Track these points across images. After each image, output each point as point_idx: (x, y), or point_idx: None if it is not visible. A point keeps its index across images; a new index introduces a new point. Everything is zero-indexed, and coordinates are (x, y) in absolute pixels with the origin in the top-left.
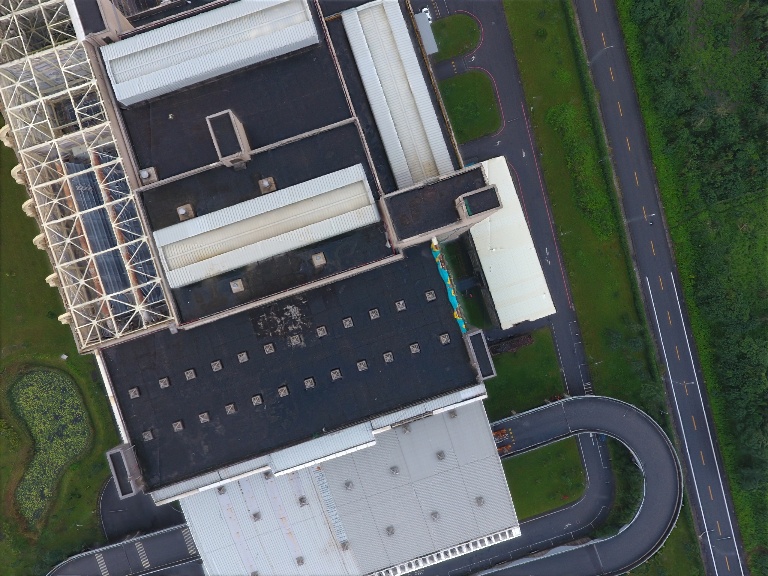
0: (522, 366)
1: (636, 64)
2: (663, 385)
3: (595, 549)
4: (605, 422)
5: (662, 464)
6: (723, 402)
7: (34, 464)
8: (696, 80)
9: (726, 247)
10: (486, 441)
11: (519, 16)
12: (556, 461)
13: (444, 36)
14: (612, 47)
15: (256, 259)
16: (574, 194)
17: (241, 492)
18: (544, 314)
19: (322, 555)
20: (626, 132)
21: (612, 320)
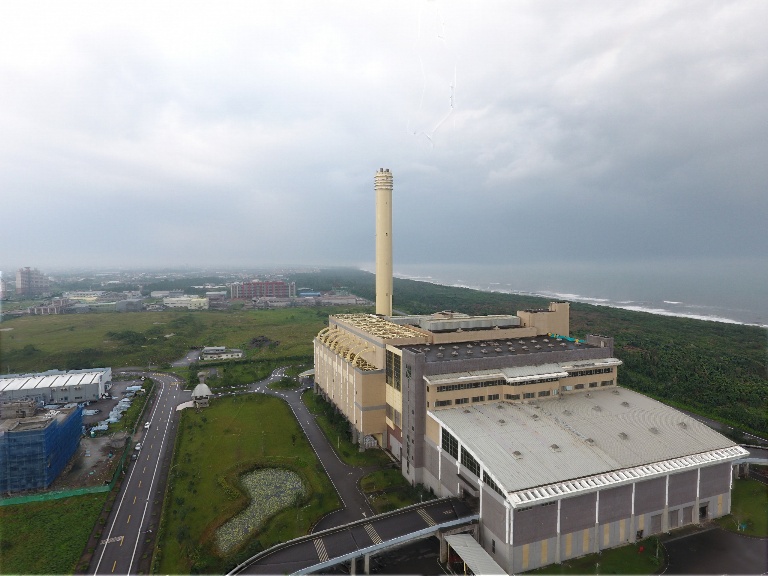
0: None
1: None
2: None
3: None
4: None
5: None
6: None
7: (245, 512)
8: None
9: None
10: None
11: None
12: (766, 495)
13: None
14: None
15: (469, 321)
16: None
17: (483, 414)
18: None
19: (573, 447)
20: None
21: None
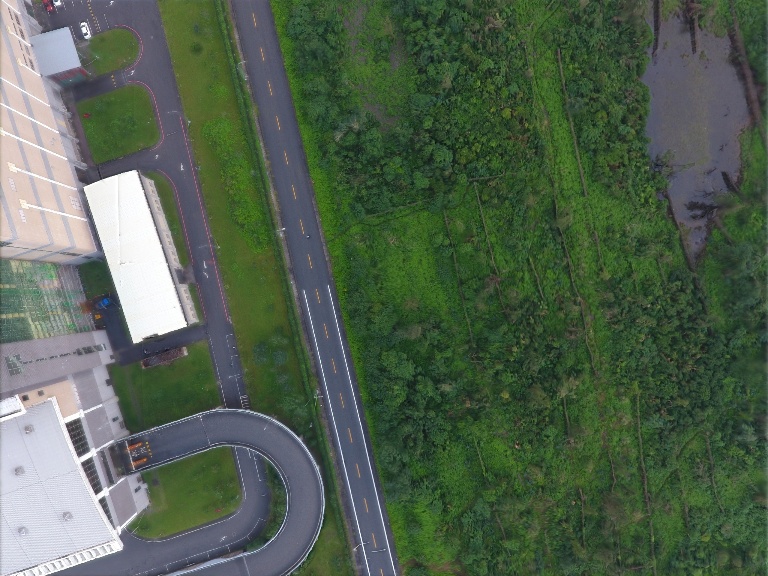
0: (178, 379)
1: (292, 78)
2: (318, 398)
3: (244, 562)
4: (246, 435)
5: (305, 477)
6: (377, 415)
7: None
8: (354, 94)
9: (375, 260)
10: (66, 456)
11: (177, 30)
12: (211, 474)
13: (103, 50)
14: (271, 61)
15: None
16: (229, 207)
17: None
18: (173, 328)
19: None
20: (284, 146)
21: (267, 333)
